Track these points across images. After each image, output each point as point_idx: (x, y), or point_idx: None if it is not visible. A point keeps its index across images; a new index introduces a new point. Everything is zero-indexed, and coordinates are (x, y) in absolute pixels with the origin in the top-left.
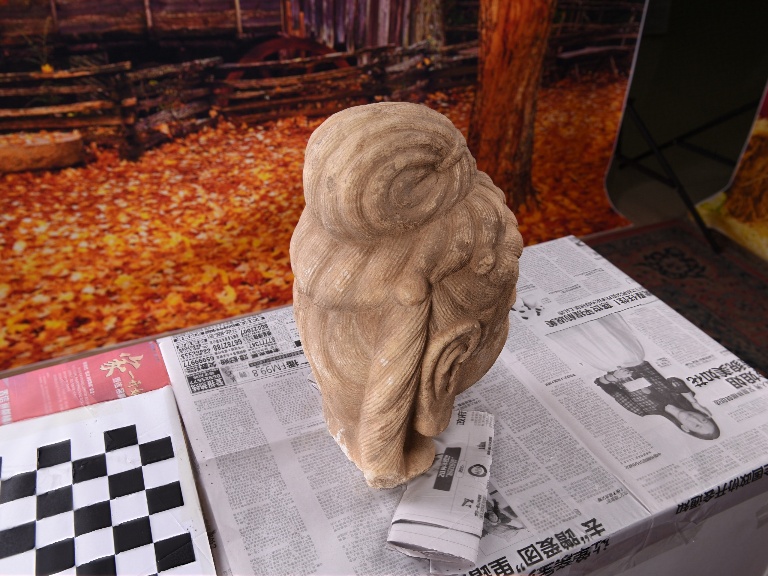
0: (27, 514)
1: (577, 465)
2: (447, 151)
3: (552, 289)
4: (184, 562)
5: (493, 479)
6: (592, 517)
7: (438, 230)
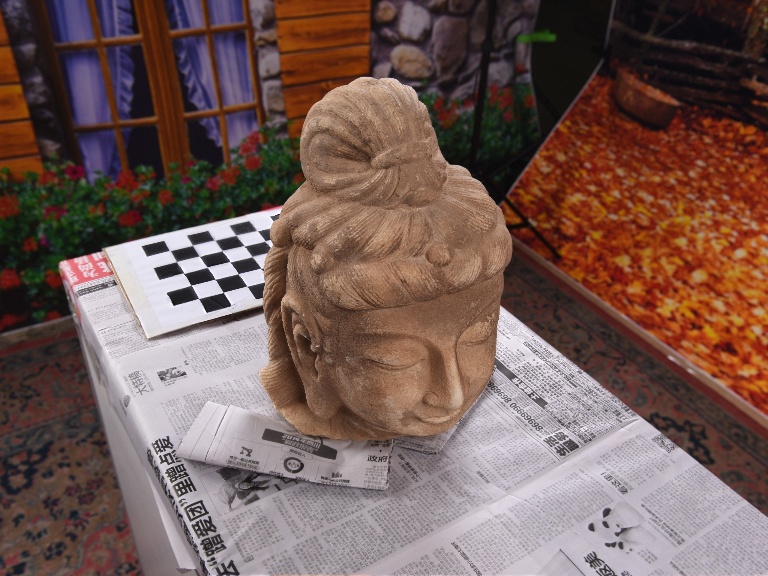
0: (250, 242)
1: (320, 567)
2: (377, 149)
3: (686, 567)
4: (207, 308)
5: (297, 488)
6: (242, 572)
7: (320, 203)
